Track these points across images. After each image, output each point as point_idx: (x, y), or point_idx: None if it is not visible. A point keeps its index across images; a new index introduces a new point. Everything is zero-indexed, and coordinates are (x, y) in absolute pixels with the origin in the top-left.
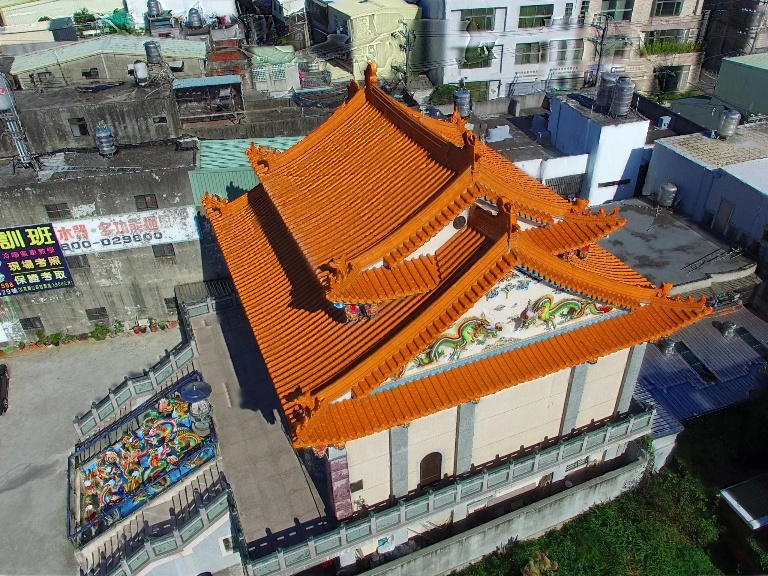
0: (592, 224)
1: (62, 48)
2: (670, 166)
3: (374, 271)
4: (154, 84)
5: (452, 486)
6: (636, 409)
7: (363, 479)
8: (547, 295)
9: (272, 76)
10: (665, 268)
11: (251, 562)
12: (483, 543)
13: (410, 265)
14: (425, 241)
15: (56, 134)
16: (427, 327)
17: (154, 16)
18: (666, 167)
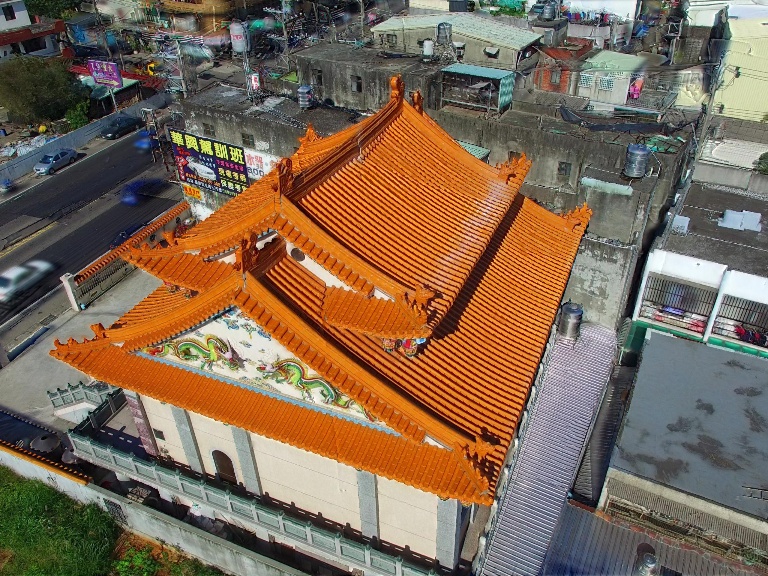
0: (408, 319)
1: (422, 17)
2: None
3: (194, 257)
4: (435, 62)
5: (223, 492)
6: (469, 575)
7: (164, 432)
8: (296, 359)
9: (599, 84)
10: (721, 470)
11: (71, 433)
12: (258, 571)
13: (222, 267)
14: (225, 249)
15: (341, 85)
16: (176, 322)
17: (541, 2)
18: None
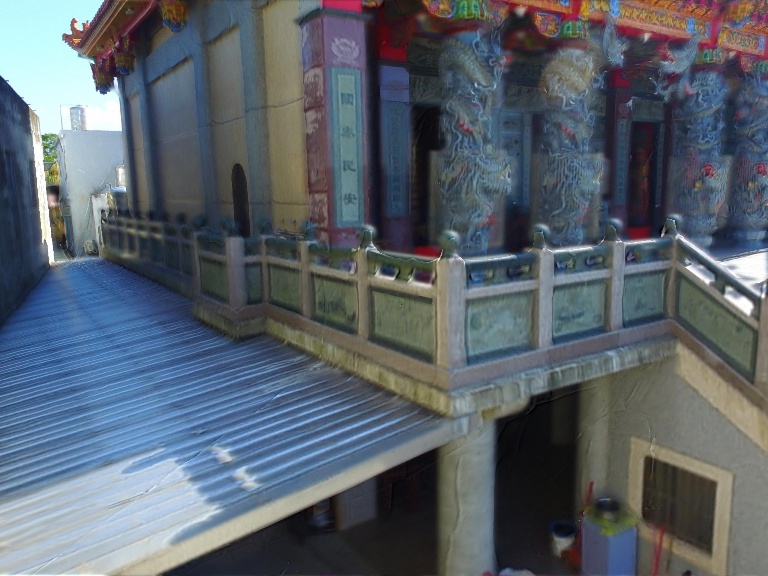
0: None
1: None
2: (102, 151)
3: None
4: None
5: None
6: None
7: None
8: None
9: None
10: None
11: None
12: None
13: None
14: None
15: None
16: None
17: None
18: (97, 154)
